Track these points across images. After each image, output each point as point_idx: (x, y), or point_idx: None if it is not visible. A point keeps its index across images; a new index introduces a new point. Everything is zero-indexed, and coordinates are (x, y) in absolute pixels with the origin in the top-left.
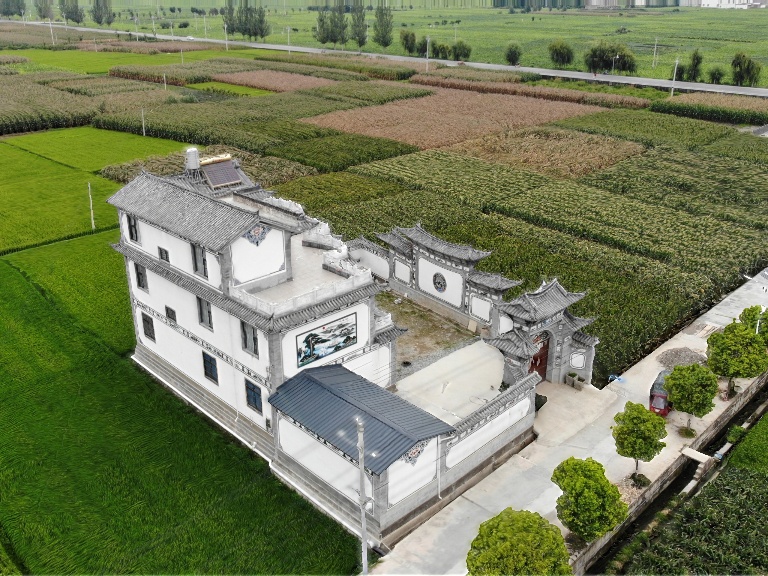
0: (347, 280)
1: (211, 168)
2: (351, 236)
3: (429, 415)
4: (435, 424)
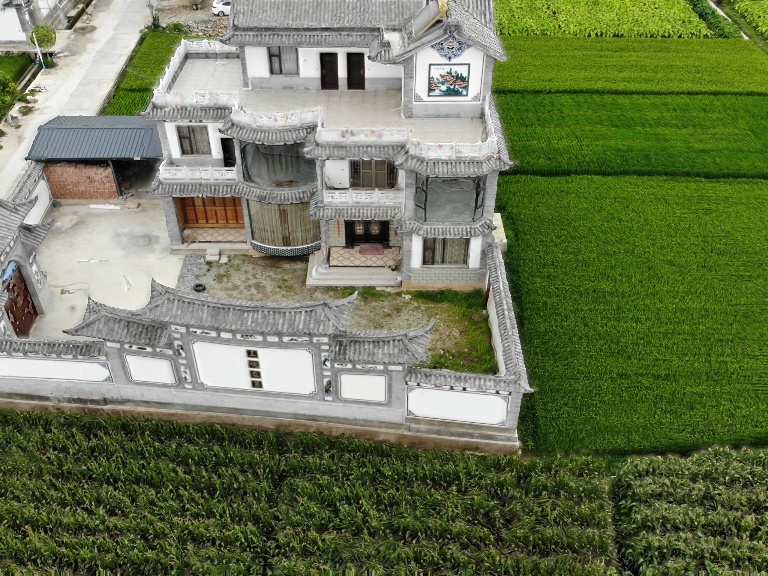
0: (163, 79)
1: (433, 4)
2: (696, 507)
3: (56, 157)
4: (43, 150)
